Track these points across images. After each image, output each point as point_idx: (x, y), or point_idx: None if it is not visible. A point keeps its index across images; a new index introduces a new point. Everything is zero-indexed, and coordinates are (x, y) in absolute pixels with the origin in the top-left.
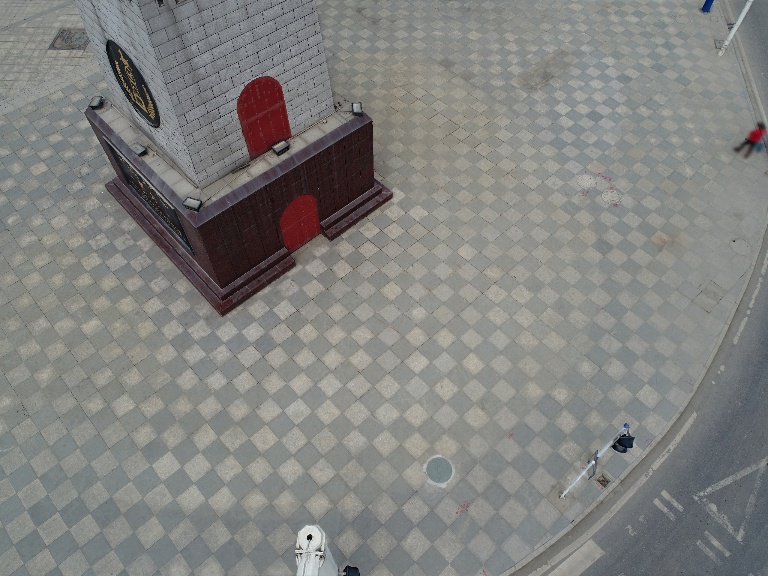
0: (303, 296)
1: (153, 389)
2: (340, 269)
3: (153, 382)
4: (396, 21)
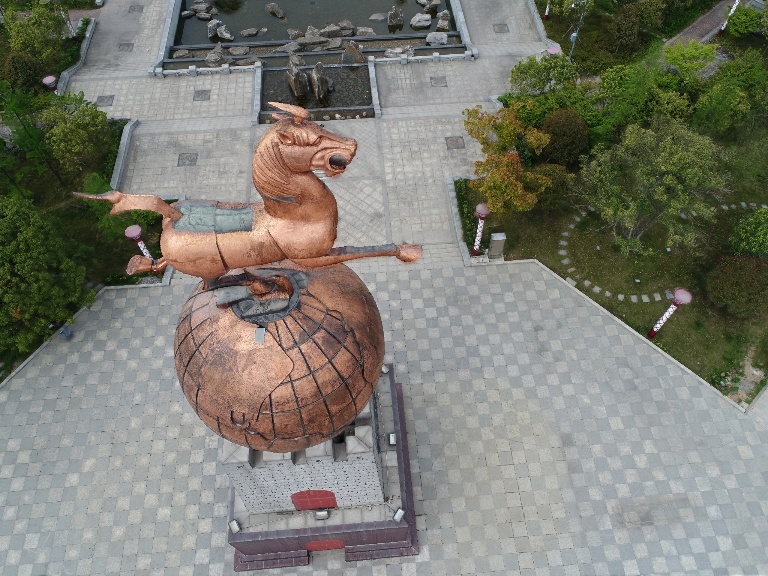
0: None
1: None
2: None
3: None
4: (559, 361)
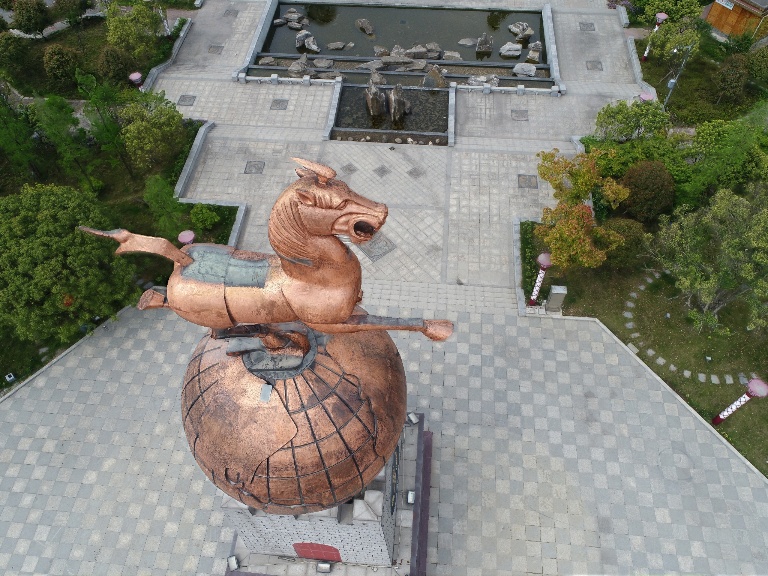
0: None
1: None
2: None
3: None
4: (608, 435)
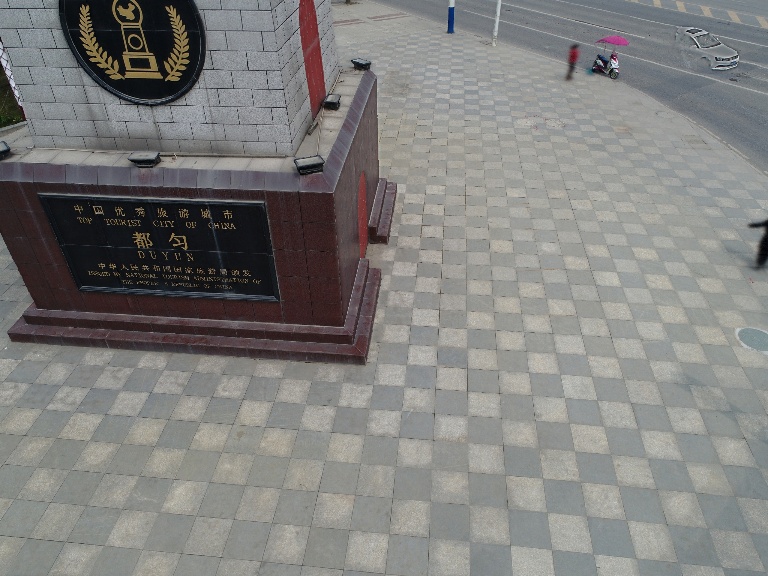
0: (427, 296)
1: (384, 497)
2: (430, 257)
3: (373, 489)
4: None
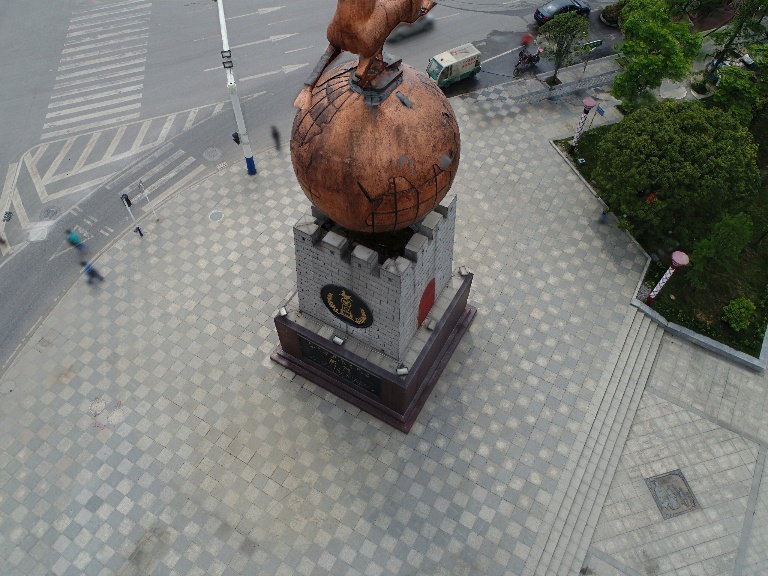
0: None
1: None
2: None
3: None
4: None
